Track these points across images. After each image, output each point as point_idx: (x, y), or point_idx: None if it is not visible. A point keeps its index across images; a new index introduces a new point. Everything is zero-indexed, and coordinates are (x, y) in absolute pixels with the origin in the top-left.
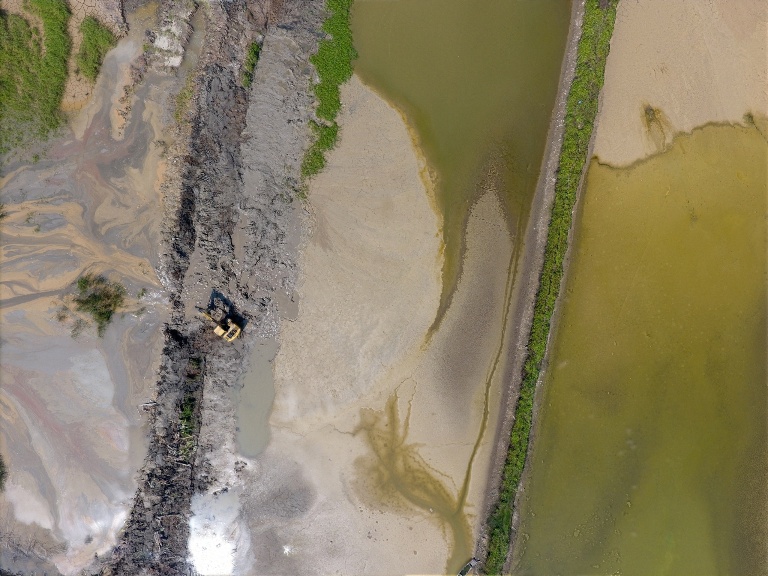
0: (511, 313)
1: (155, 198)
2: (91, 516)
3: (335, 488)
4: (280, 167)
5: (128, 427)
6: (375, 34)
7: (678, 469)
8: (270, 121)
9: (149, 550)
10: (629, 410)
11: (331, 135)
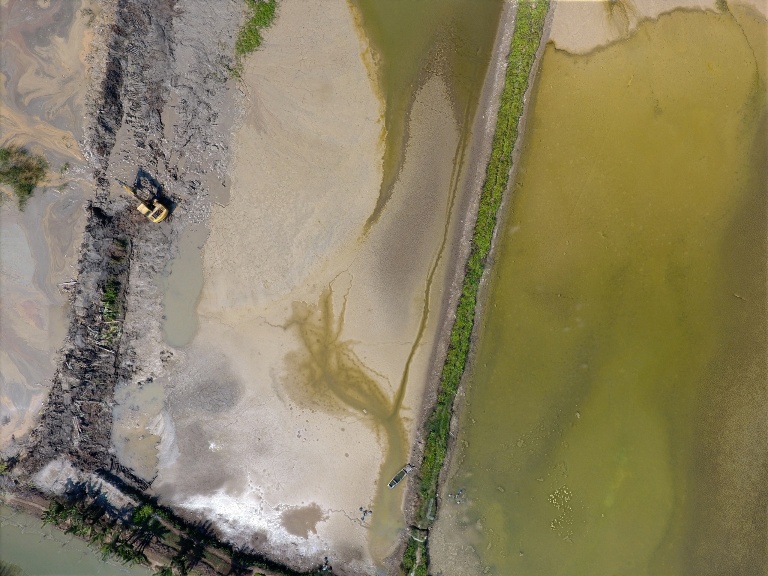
0: (456, 206)
1: (80, 69)
2: (8, 396)
3: (264, 383)
4: (214, 44)
5: (48, 306)
6: None
7: (633, 380)
8: None
9: (67, 435)
10: (581, 315)
11: (268, 11)
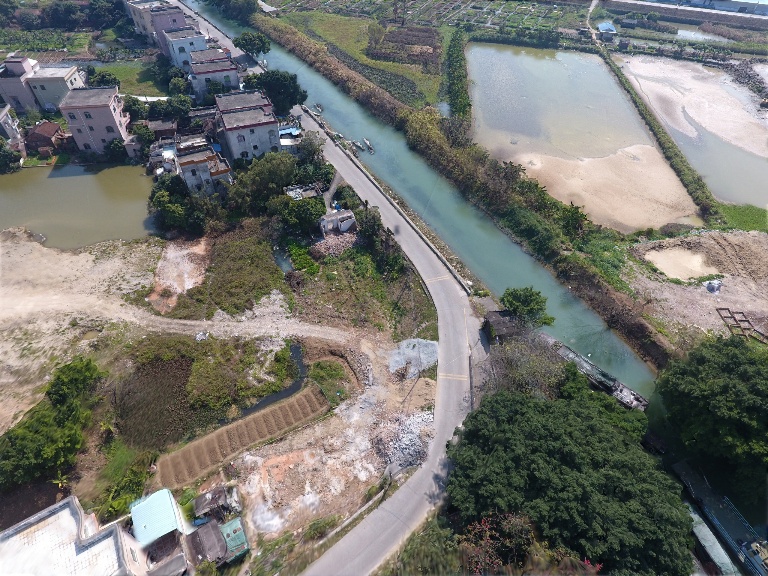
0: None
1: None
2: None
3: None
4: None
5: None
6: None
7: None
8: None
9: None
10: None
11: None
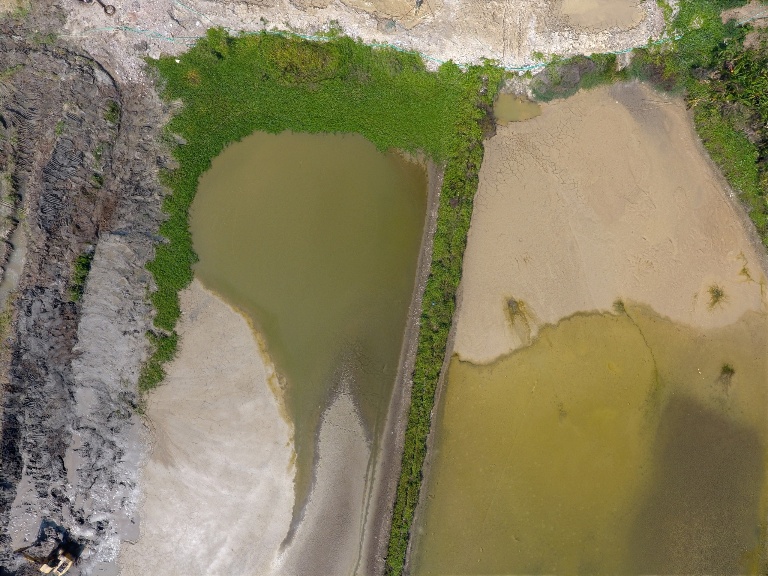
0: (369, 523)
1: None
2: None
3: None
4: (116, 382)
5: None
6: (217, 235)
7: None
8: (104, 334)
9: None
10: None
11: (170, 346)
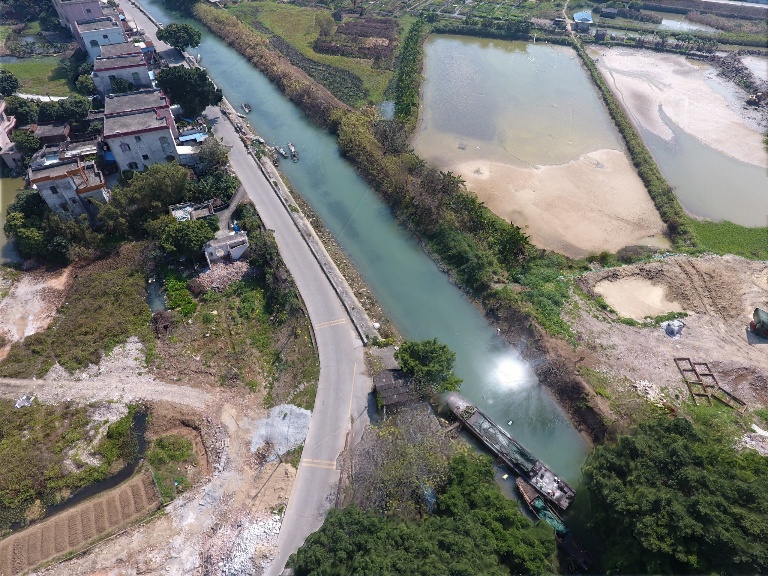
0: None
1: None
2: None
3: (666, 74)
4: None
5: (767, 78)
6: None
7: None
8: None
9: None
10: (551, 89)
11: None
